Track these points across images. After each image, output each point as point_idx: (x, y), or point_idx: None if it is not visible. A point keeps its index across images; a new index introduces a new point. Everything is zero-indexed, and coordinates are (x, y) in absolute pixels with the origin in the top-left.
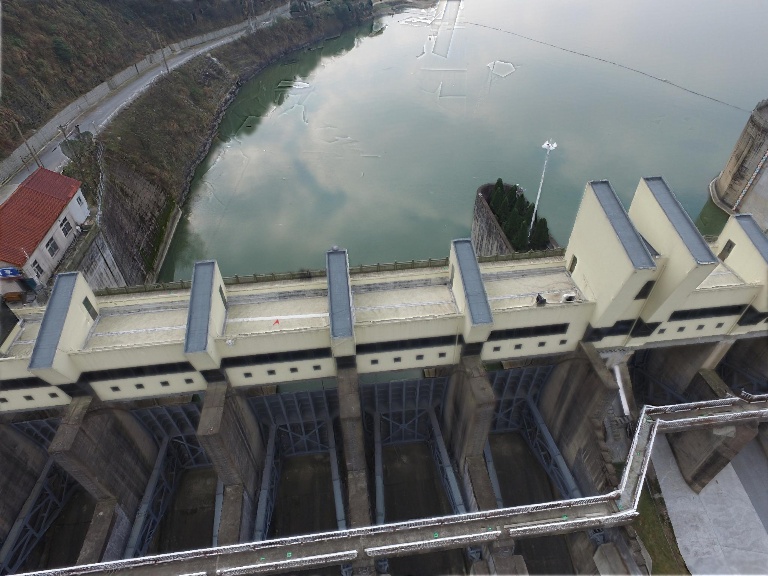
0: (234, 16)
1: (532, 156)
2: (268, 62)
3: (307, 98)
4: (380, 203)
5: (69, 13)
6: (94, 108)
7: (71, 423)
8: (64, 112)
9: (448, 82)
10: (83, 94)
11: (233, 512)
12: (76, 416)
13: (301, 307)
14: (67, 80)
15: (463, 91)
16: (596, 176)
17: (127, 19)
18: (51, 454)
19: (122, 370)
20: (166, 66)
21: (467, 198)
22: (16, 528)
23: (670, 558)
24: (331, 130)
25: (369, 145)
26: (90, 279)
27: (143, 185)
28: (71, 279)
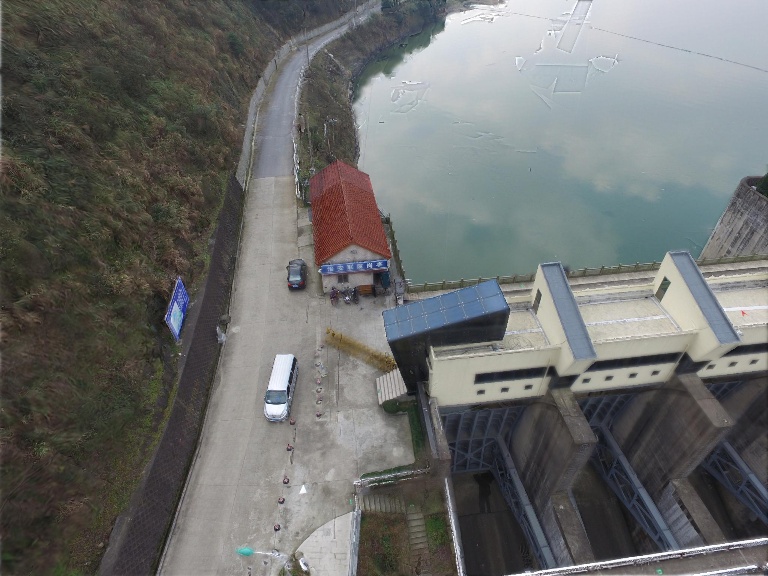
0: (333, 12)
1: (690, 151)
2: (368, 58)
3: (425, 94)
4: (562, 198)
5: (224, 8)
6: (266, 103)
7: (574, 415)
8: (251, 107)
9: (564, 78)
10: (254, 89)
11: (698, 506)
12: (572, 408)
13: (752, 298)
14: (244, 75)
15: (578, 87)
16: (767, 171)
17: (254, 15)
18: (578, 446)
19: (604, 362)
20: (308, 62)
21: (648, 193)
22: (454, 522)
23: None
24: (469, 126)
25: (516, 140)
26: None
27: None
28: (554, 269)
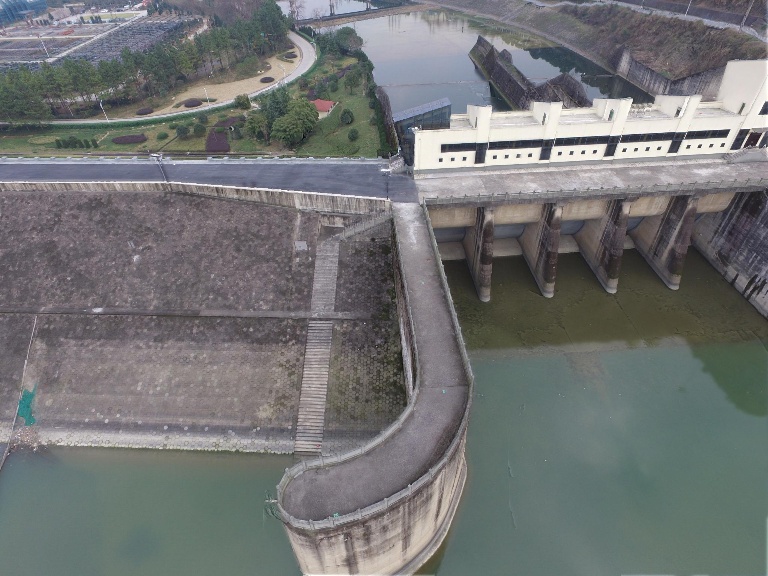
0: None
1: None
2: None
3: None
4: None
5: None
6: None
7: None
8: None
9: None
10: None
11: None
12: None
13: None
14: None
15: None
16: None
17: None
18: None
19: None
20: None
21: None
22: None
23: None
24: None
25: None
26: None
27: None
28: None
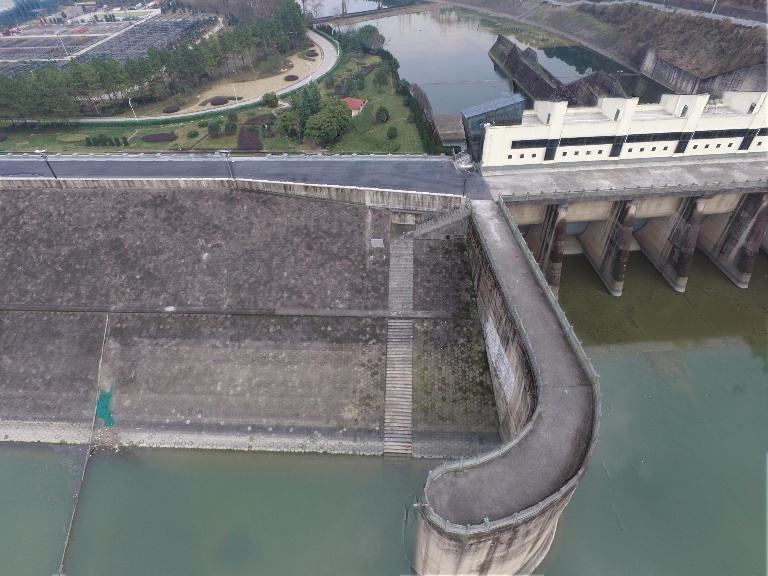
0: None
1: None
2: None
3: None
4: None
5: None
6: None
7: None
8: None
9: None
10: None
11: None
12: None
13: None
14: None
15: None
16: None
17: None
18: None
19: None
20: None
21: None
22: None
23: None
24: None
25: None
26: None
27: None
28: None
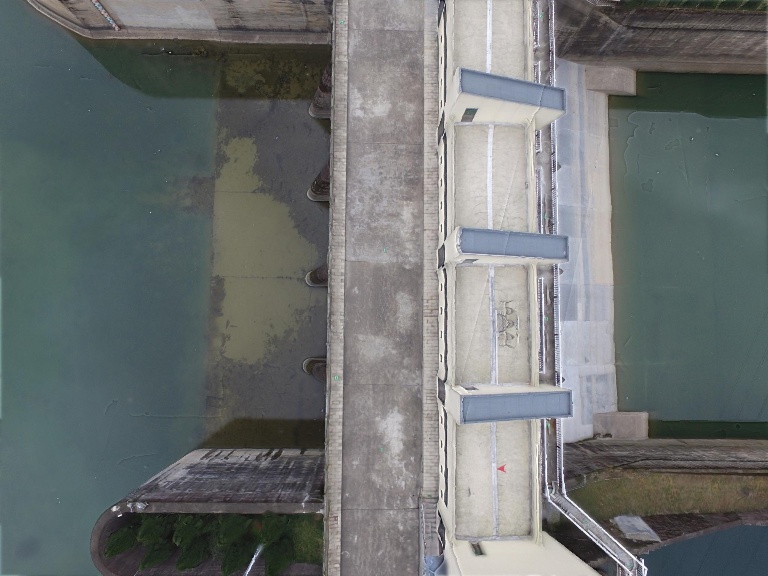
0: None
1: None
2: None
3: None
4: None
5: None
6: None
7: None
8: None
9: None
10: None
11: None
12: None
13: None
14: None
15: None
16: None
17: None
18: None
19: None
20: None
21: None
22: None
23: (620, 484)
24: None
25: None
26: None
27: None
28: None
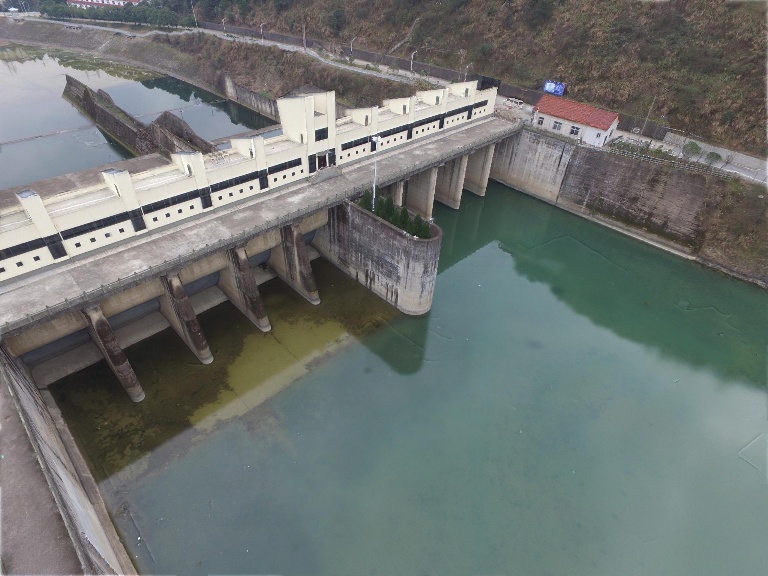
0: None
1: None
2: None
3: None
4: (593, 351)
5: None
6: None
7: None
8: None
9: None
10: None
11: None
12: None
13: None
14: None
15: None
16: None
17: None
18: None
19: None
20: None
21: (530, 412)
22: None
23: None
24: None
25: None
26: (545, 148)
27: (685, 207)
28: None
